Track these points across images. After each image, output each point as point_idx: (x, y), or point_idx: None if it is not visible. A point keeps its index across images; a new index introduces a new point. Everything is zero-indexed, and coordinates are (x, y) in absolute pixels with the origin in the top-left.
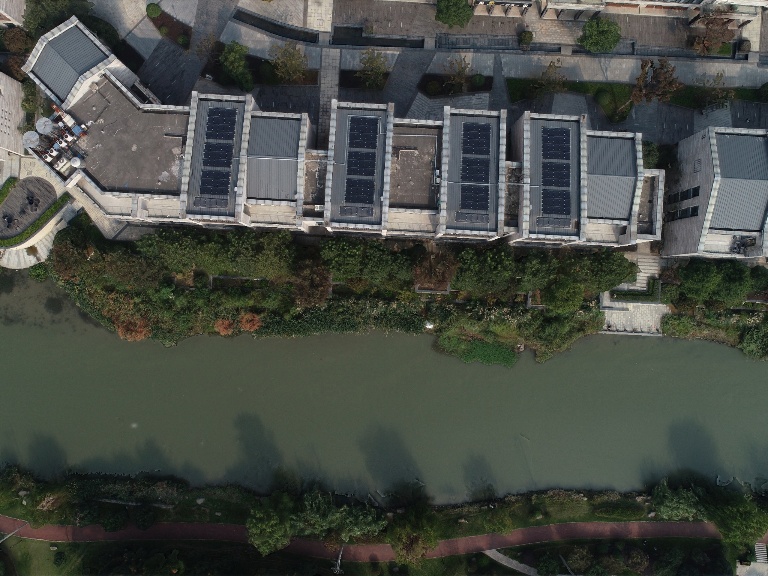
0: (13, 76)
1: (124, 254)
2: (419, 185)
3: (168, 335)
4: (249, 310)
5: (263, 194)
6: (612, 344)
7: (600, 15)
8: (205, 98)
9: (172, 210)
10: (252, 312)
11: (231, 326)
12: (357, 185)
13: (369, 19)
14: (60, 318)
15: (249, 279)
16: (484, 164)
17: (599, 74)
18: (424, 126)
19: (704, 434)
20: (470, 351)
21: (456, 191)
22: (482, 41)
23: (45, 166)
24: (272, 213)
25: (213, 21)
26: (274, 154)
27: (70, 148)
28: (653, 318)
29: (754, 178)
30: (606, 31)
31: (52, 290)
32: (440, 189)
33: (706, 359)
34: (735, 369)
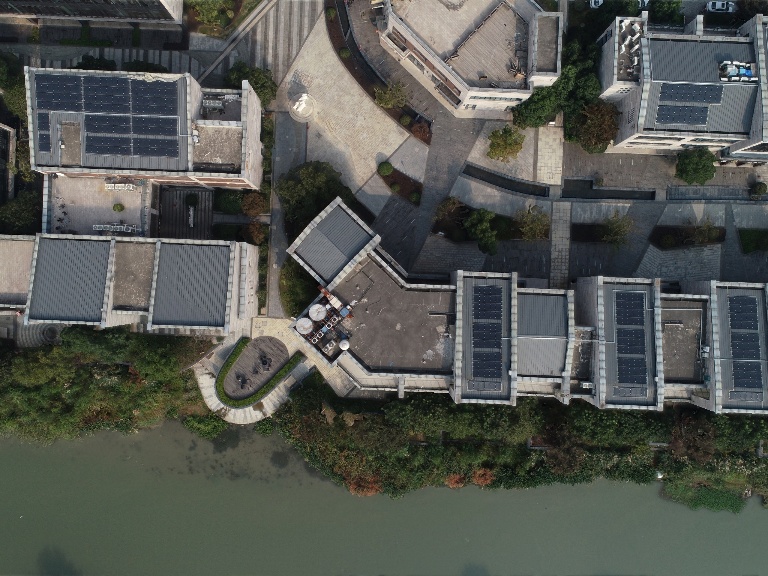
0: (253, 242)
1: (372, 422)
2: (684, 359)
3: (400, 491)
4: (481, 464)
5: (528, 371)
6: None
7: None
8: (469, 276)
9: (426, 381)
10: (484, 466)
11: (463, 480)
12: (629, 364)
13: (599, 172)
14: (286, 472)
15: (479, 432)
16: (753, 339)
17: None
18: (688, 299)
19: None
20: (697, 498)
21: (728, 368)
22: (712, 191)
23: (312, 348)
24: (526, 382)
25: (443, 176)
26: (543, 333)
27: (335, 329)
28: None
29: None
30: None
31: (278, 444)
32: (707, 363)
33: None
34: None
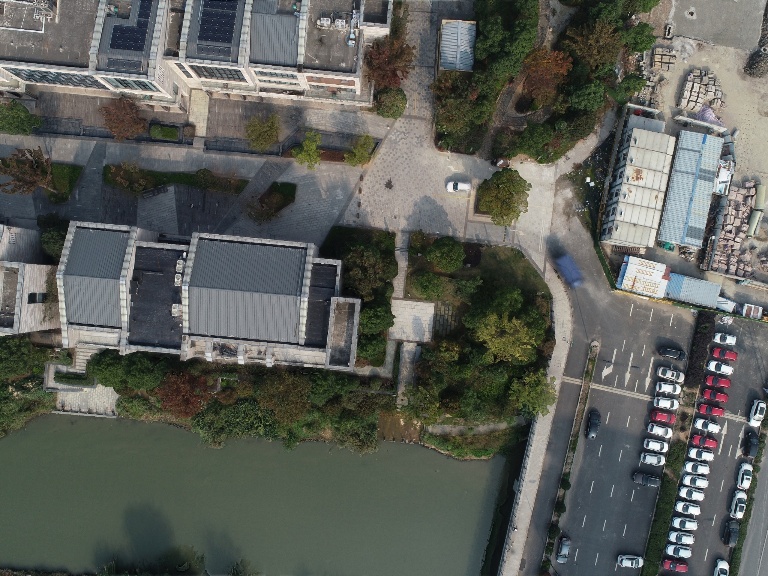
0: None
1: None
2: None
3: None
4: None
5: None
6: (69, 424)
7: (46, 94)
8: None
9: None
10: None
11: None
12: None
13: None
14: None
15: None
16: None
17: (43, 153)
18: None
19: (160, 518)
20: None
21: None
22: None
23: None
24: None
25: None
26: None
27: None
28: (109, 399)
29: (101, 276)
30: (8, 116)
31: None
32: None
33: (166, 442)
34: (198, 453)
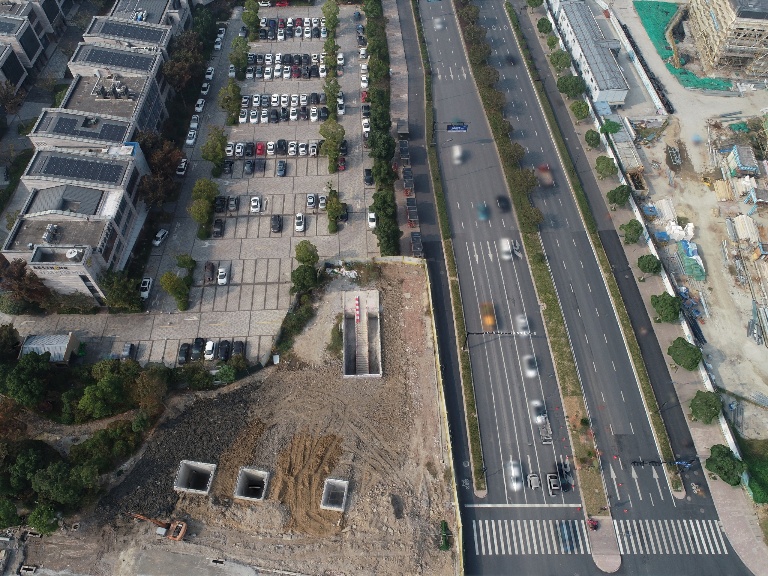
0: None
1: None
2: None
3: None
4: None
5: None
6: None
7: None
8: None
9: None
10: None
11: None
12: None
13: None
14: None
15: None
16: None
17: None
18: None
19: None
20: None
21: None
22: None
23: None
24: None
25: None
26: None
27: None
28: None
29: None
30: None
31: None
32: None
33: None
34: None
